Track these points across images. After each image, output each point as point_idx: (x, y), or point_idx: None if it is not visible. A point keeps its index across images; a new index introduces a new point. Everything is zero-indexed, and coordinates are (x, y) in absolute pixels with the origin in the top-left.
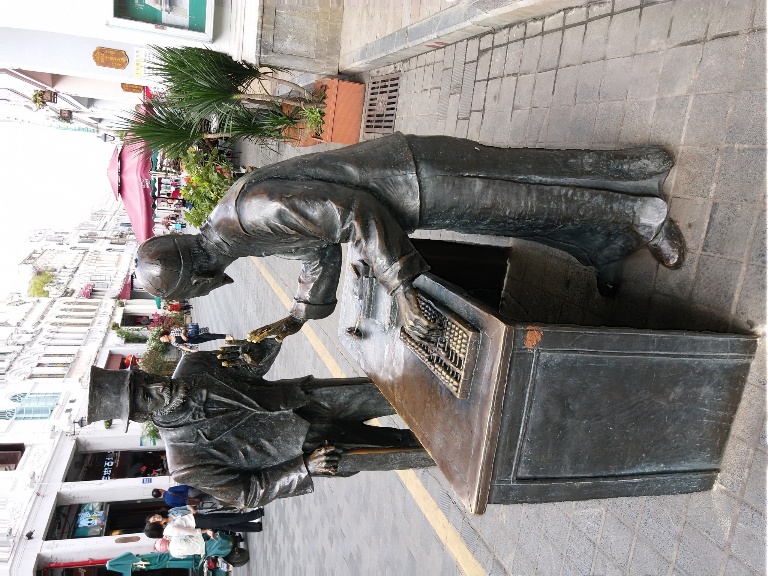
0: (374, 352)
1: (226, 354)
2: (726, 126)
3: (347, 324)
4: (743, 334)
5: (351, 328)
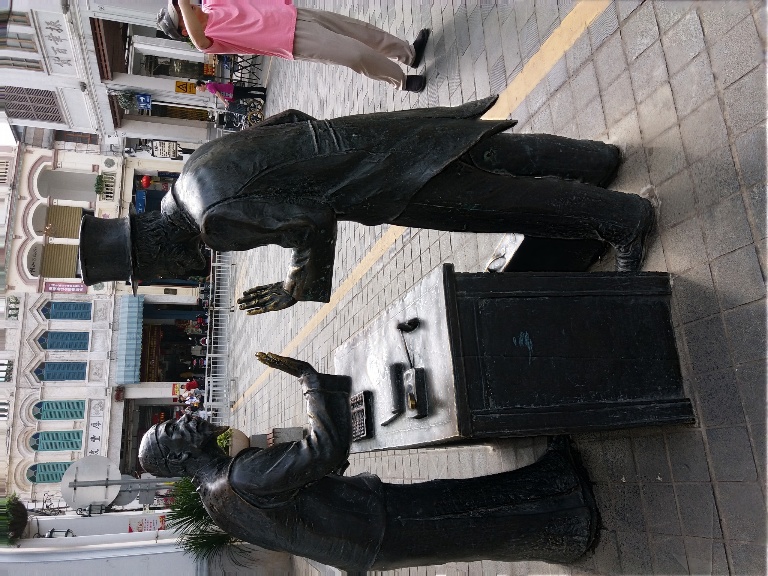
0: (393, 336)
1: (247, 301)
2: (531, 574)
3: (431, 309)
4: (489, 444)
5: (409, 326)
